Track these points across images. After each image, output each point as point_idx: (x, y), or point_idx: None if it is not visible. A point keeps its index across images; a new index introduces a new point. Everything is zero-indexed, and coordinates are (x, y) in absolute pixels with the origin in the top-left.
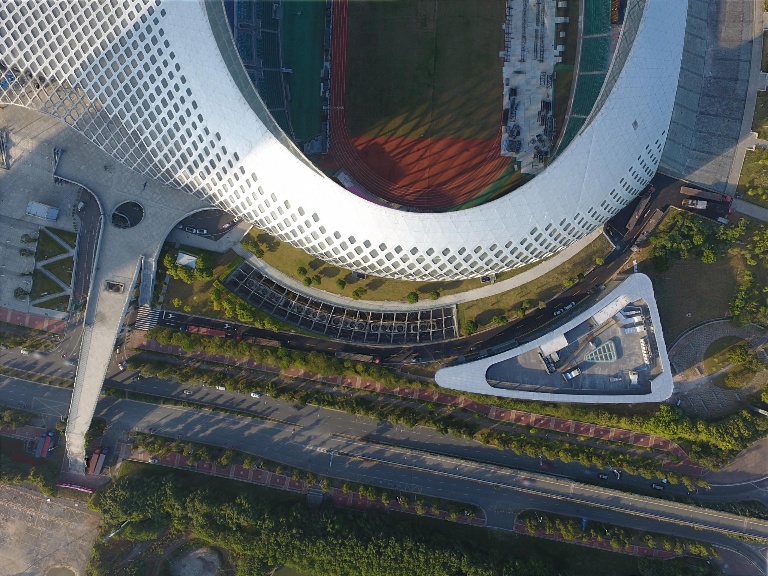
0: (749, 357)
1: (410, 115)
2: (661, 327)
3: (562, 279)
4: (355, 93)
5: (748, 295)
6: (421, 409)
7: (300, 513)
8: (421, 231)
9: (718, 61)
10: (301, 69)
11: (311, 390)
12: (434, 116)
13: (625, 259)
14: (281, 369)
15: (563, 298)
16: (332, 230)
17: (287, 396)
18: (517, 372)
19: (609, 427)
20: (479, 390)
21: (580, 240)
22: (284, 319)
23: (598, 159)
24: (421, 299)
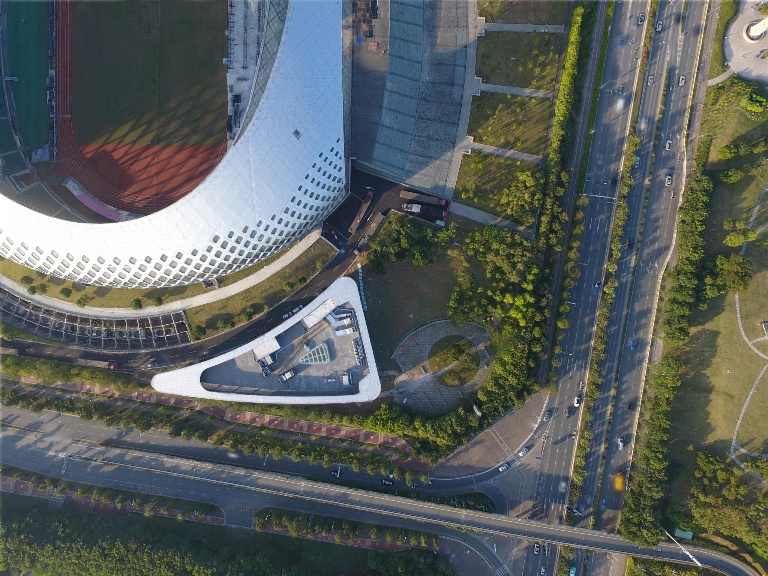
0: (463, 356)
1: (136, 122)
2: (367, 329)
3: (283, 283)
4: (82, 101)
5: (468, 295)
6: (159, 413)
7: (34, 518)
8: (98, 241)
9: (435, 66)
10: (27, 77)
11: (51, 397)
12: (160, 123)
13: (350, 262)
14: (20, 377)
15: (292, 301)
16: (18, 241)
17: (21, 404)
18: (236, 375)
19: (339, 426)
20: (194, 394)
21: (299, 245)
22: (21, 327)
23: (262, 168)
24: (150, 305)
